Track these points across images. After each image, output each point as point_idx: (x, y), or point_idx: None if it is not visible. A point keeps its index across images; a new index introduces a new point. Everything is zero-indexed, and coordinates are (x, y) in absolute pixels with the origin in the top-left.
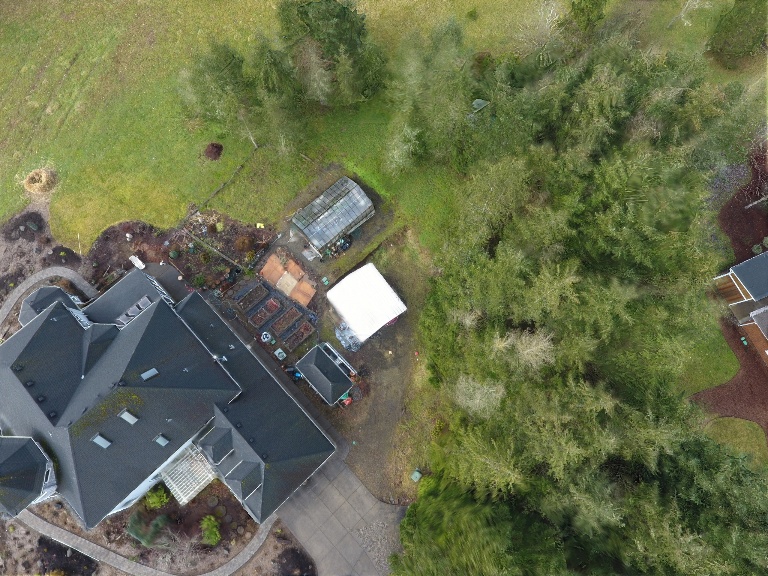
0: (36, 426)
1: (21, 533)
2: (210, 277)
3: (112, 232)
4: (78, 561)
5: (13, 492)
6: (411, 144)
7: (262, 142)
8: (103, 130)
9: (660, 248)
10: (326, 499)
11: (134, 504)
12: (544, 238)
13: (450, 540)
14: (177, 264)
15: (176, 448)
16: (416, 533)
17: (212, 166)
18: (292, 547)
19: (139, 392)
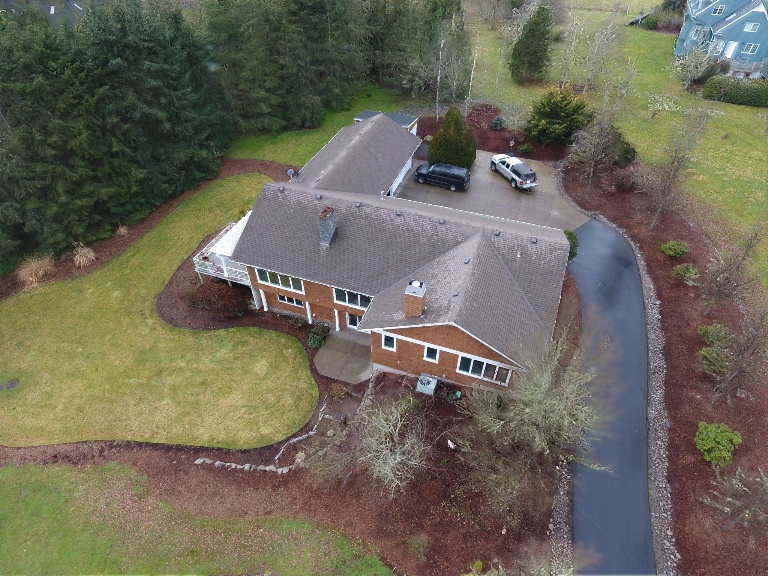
0: None
1: None
2: None
3: None
4: None
5: None
6: None
7: None
8: None
9: None
10: None
11: None
12: None
13: None
14: None
15: None
16: None
17: None
18: None
19: (66, 5)
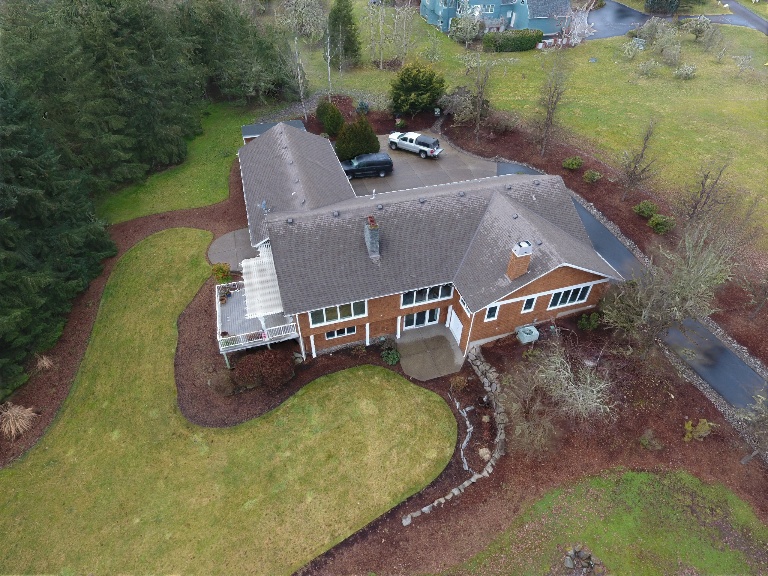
0: None
1: None
2: None
3: None
4: None
5: None
6: None
7: None
8: None
9: None
10: None
11: None
12: None
13: None
14: None
15: None
16: None
17: None
18: None
19: None
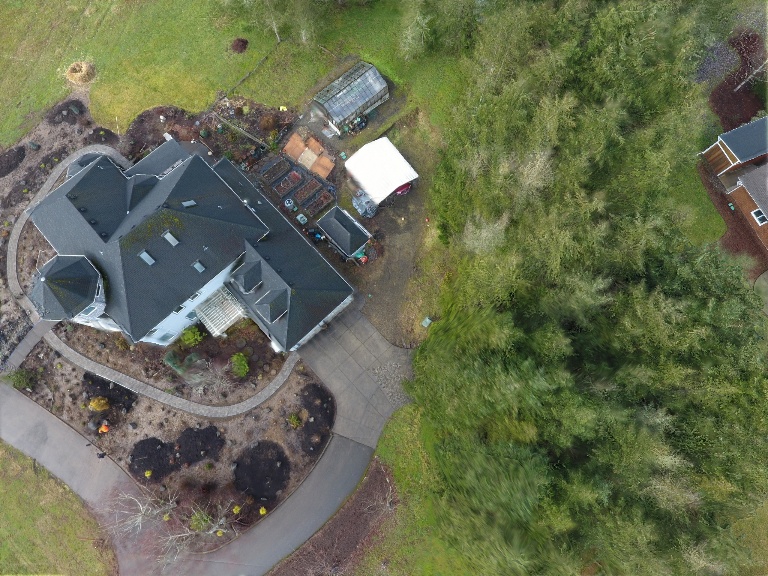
0: (88, 248)
1: (68, 370)
2: (237, 152)
3: (147, 115)
4: (120, 392)
5: (70, 295)
6: (423, 31)
7: (284, 37)
8: (137, 29)
9: (649, 84)
10: (344, 343)
11: (170, 345)
12: (544, 74)
13: (458, 352)
14: (207, 142)
15: (211, 277)
16: (427, 363)
17: (238, 58)
18: (313, 383)
19: (180, 216)
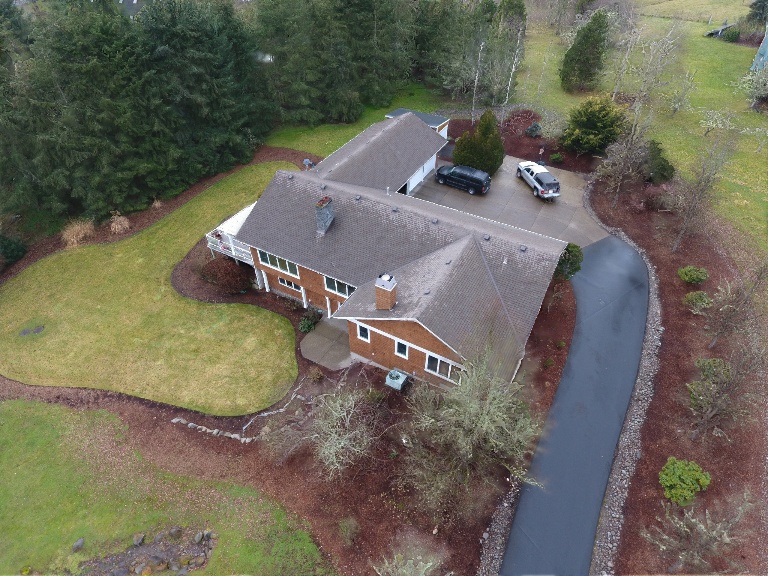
0: None
1: None
2: None
3: None
4: None
5: None
6: None
7: None
8: None
9: None
10: None
11: None
12: None
13: None
14: None
15: None
16: None
17: None
18: None
19: None
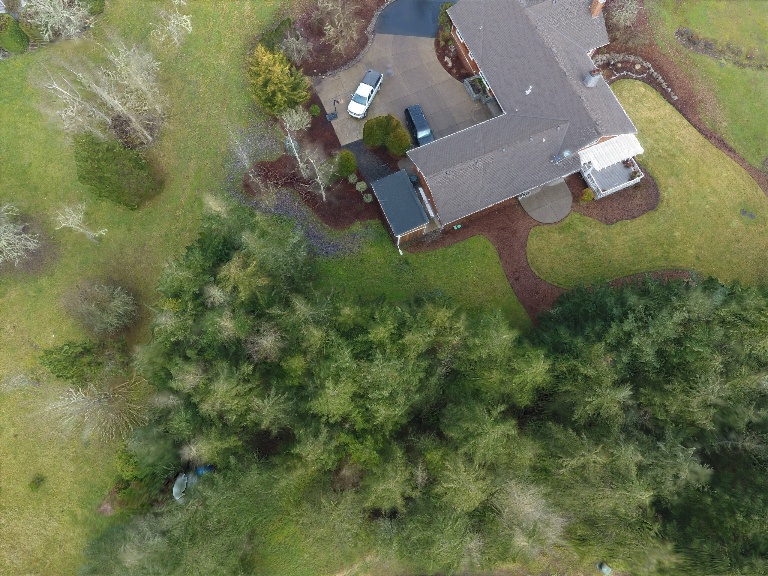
0: None
1: None
2: None
3: None
4: None
5: None
6: None
7: None
8: None
9: None
10: None
11: None
12: (410, 496)
13: (688, 569)
14: None
15: None
16: None
17: None
18: None
19: None
